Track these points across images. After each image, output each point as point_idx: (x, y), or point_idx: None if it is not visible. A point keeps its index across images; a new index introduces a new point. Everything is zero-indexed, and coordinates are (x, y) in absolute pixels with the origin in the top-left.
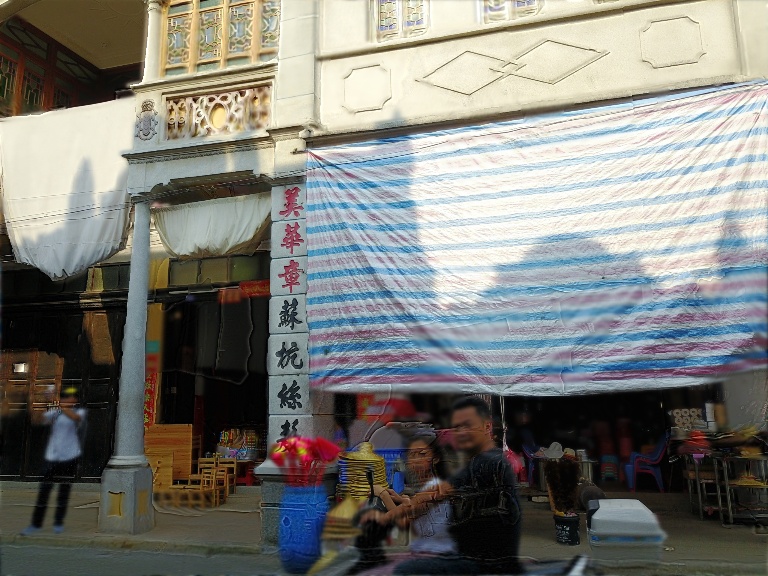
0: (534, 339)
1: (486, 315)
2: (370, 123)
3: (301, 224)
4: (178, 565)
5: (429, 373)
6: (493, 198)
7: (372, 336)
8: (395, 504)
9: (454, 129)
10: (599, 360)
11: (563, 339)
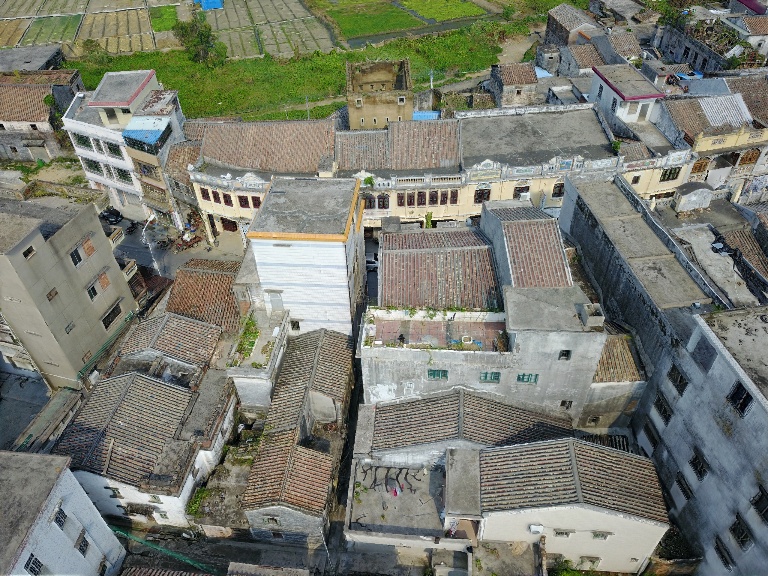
0: None
1: None
2: None
3: (750, 184)
4: None
5: None
6: None
7: None
8: None
9: None
10: None
11: None
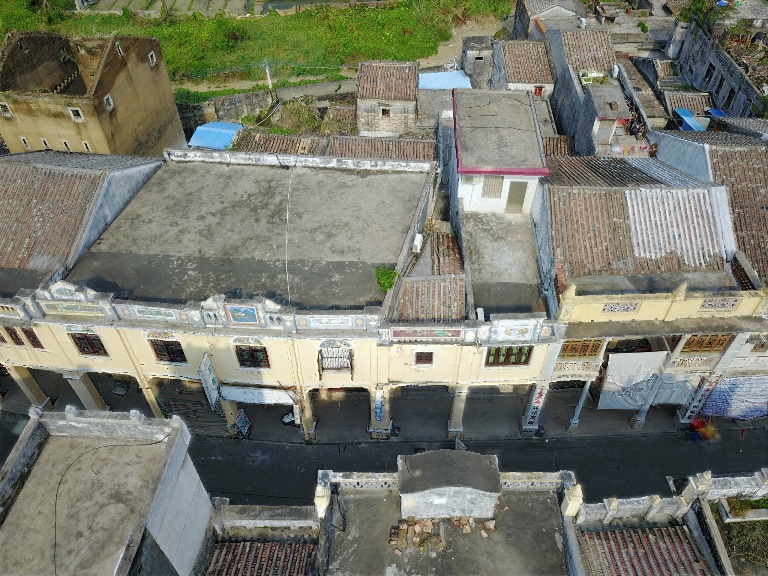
0: (755, 410)
1: (747, 406)
2: (738, 369)
3: None
4: (666, 441)
5: (732, 415)
6: (760, 387)
7: (721, 408)
8: (706, 421)
9: (759, 376)
10: (765, 413)
11: (760, 410)
